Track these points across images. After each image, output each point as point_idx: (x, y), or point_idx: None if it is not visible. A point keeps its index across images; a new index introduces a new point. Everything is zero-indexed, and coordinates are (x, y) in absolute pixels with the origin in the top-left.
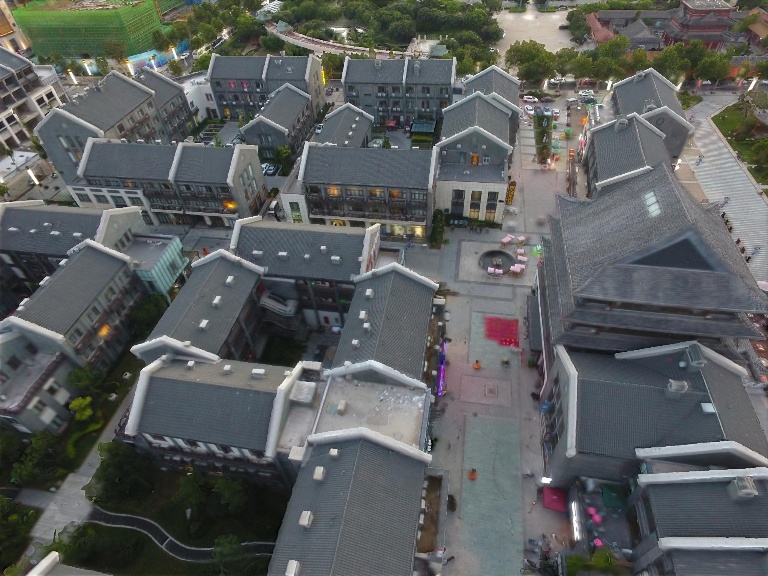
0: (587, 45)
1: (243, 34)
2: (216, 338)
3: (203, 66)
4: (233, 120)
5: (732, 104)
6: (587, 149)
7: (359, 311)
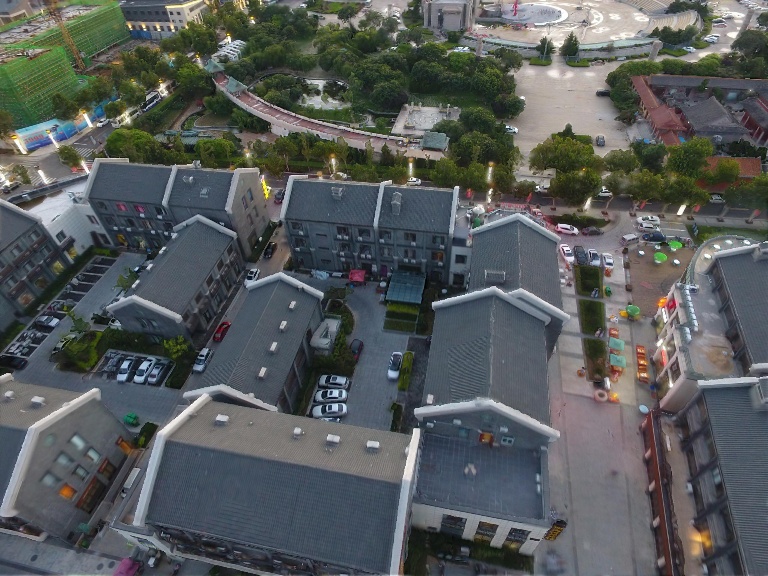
0: (637, 126)
1: (185, 90)
2: None
3: (115, 146)
4: (131, 249)
5: None
6: (680, 389)
7: None
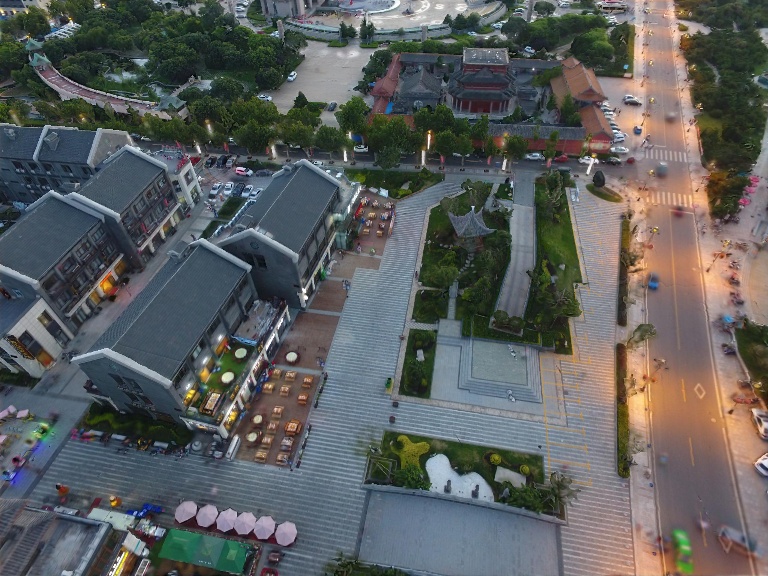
0: None
1: (3, 66)
2: None
3: None
4: None
5: (471, 188)
6: None
7: None
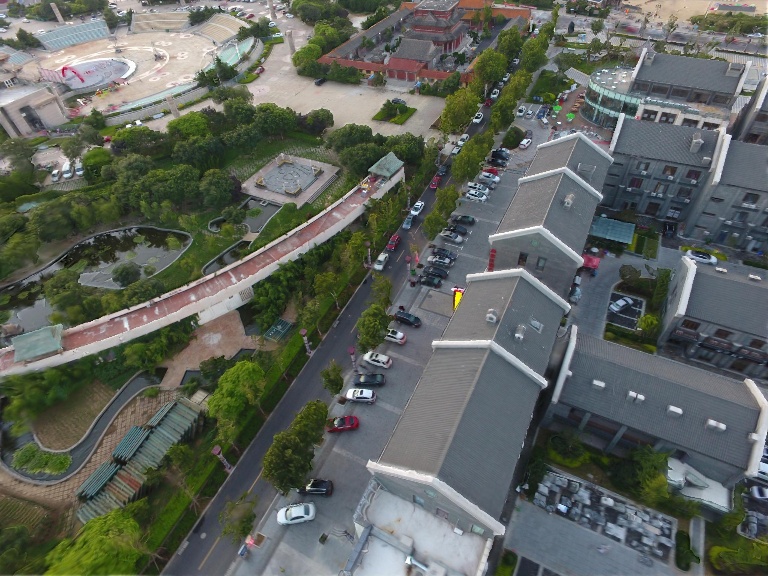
0: None
1: None
2: None
3: None
4: None
5: None
6: None
7: None
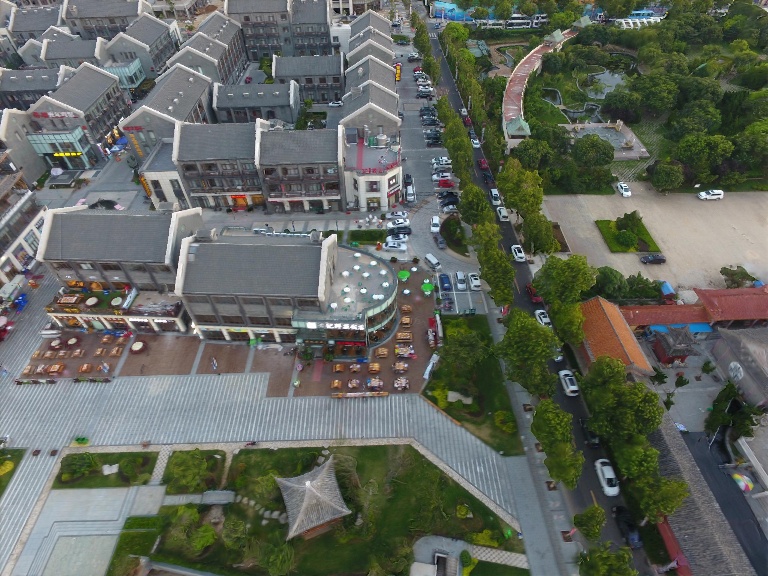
0: None
1: None
2: (10, 87)
3: None
4: None
5: (492, 508)
6: None
7: None
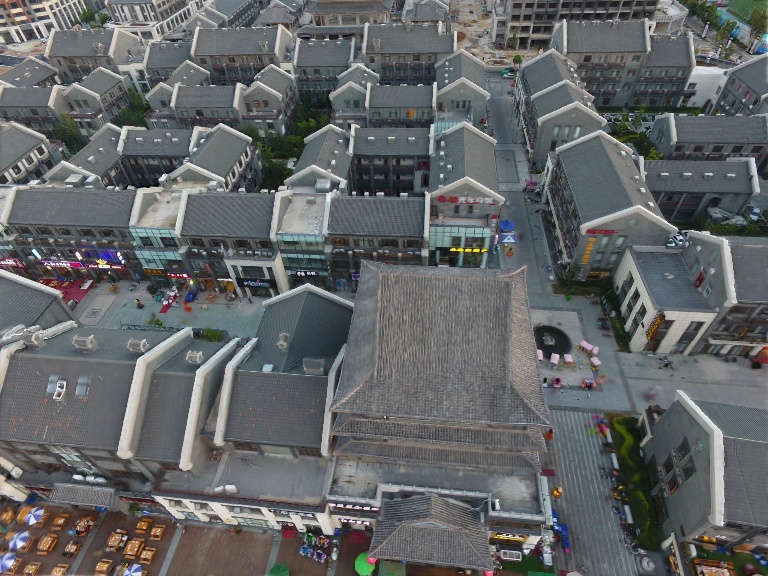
0: None
1: None
2: (366, 149)
3: None
4: None
5: None
6: None
7: (390, 197)
